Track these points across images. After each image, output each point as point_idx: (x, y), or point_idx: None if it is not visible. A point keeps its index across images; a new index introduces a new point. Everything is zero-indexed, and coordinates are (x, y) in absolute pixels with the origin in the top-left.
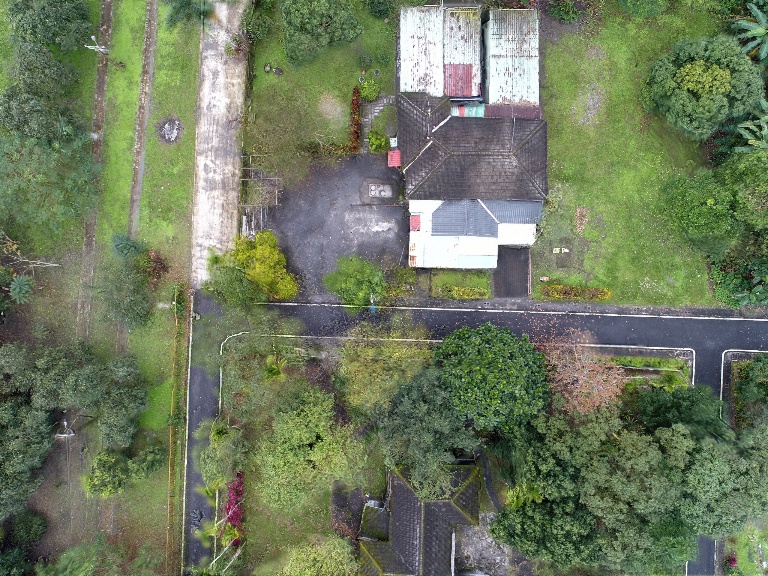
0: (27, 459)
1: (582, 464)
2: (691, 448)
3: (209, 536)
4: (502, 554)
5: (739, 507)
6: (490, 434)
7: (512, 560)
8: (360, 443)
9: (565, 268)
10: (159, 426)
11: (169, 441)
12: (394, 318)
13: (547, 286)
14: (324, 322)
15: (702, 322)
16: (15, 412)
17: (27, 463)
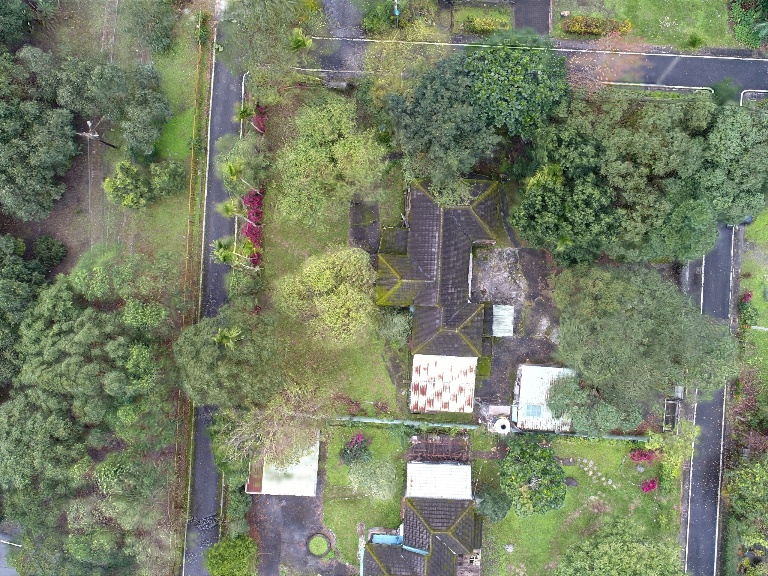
0: (52, 152)
1: (604, 135)
2: (713, 108)
3: (227, 266)
4: (518, 289)
5: (760, 160)
6: (508, 170)
7: (528, 295)
8: (381, 146)
9: (586, 6)
10: (180, 151)
11: (190, 164)
12: (415, 53)
13: (568, 20)
14: (346, 56)
15: (721, 62)
16: (41, 108)
17: (52, 155)
